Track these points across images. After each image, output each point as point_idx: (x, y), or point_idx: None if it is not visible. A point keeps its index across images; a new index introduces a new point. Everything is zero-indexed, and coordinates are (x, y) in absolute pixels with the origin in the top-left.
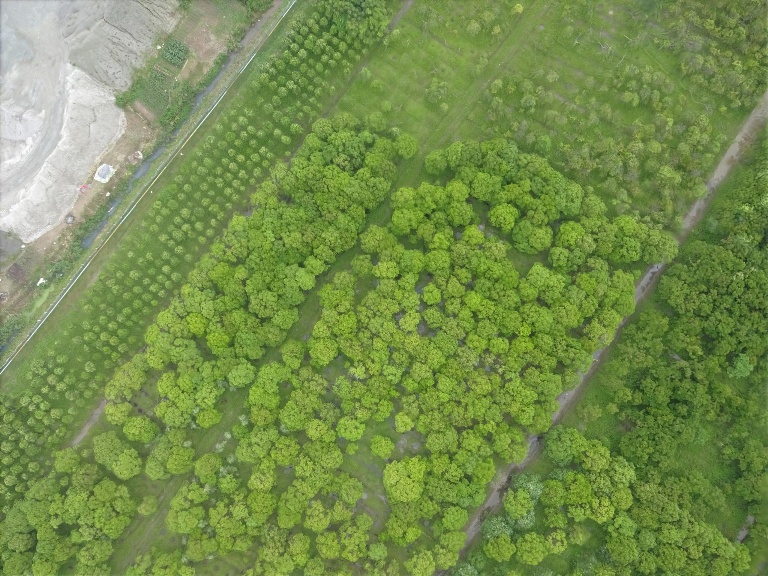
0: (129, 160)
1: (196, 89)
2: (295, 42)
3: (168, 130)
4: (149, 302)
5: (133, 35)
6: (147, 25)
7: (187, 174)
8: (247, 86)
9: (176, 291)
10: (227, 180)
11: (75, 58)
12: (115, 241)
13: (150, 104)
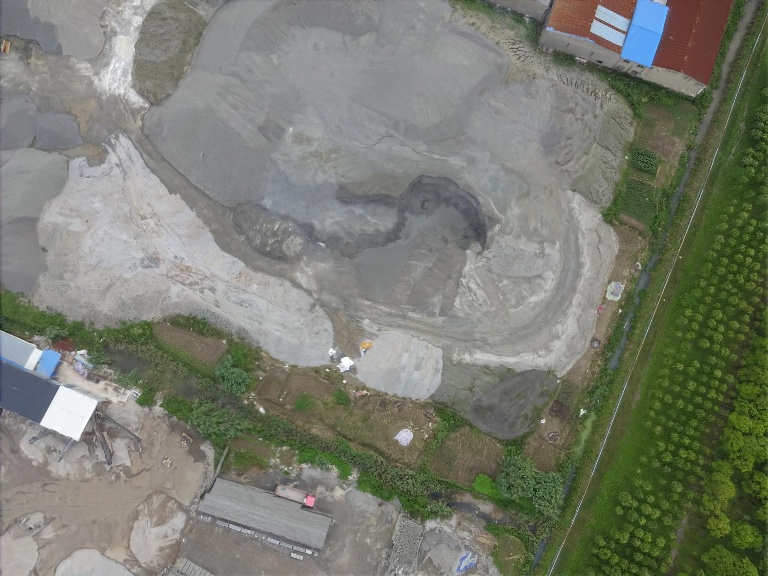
0: (632, 273)
1: (671, 192)
2: (764, 132)
3: (659, 236)
4: (711, 409)
5: (612, 151)
6: (618, 138)
7: (707, 276)
8: (721, 180)
9: (733, 392)
10: (744, 275)
11: (576, 184)
12: (645, 356)
13: (638, 214)
